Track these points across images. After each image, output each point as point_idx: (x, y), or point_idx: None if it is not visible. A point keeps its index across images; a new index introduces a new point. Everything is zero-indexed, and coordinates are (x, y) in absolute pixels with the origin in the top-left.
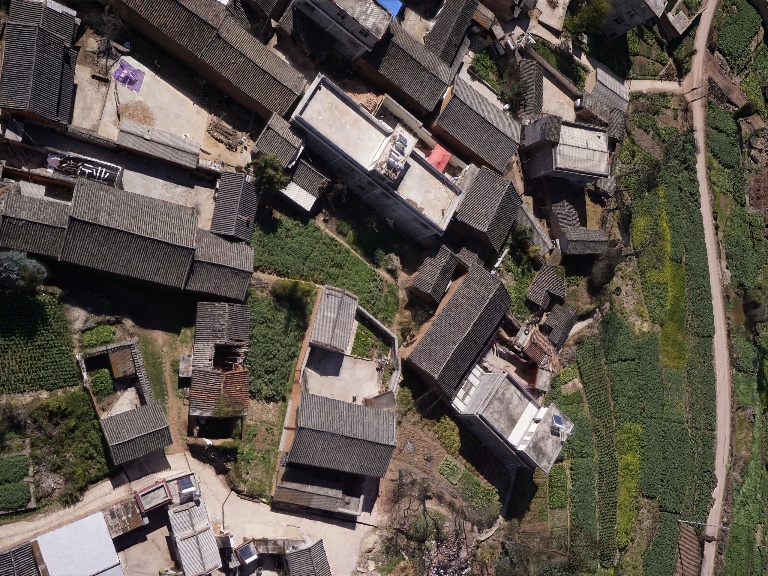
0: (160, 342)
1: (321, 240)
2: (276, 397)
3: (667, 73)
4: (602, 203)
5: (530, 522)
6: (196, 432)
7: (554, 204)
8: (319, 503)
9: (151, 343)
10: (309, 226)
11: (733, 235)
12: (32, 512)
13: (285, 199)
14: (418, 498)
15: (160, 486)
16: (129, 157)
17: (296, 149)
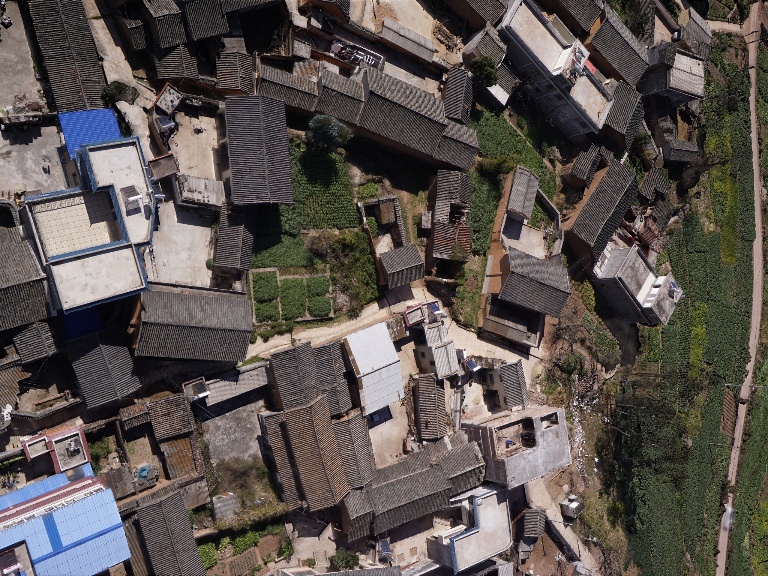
0: (405, 200)
1: (507, 131)
2: (480, 252)
3: (733, 16)
4: (688, 122)
5: (635, 370)
6: (435, 271)
7: (660, 118)
8: (512, 335)
9: (399, 200)
10: (500, 118)
11: (767, 160)
12: (330, 321)
13: (484, 95)
14: (568, 341)
15: (419, 308)
16: (383, 49)
17: (504, 53)
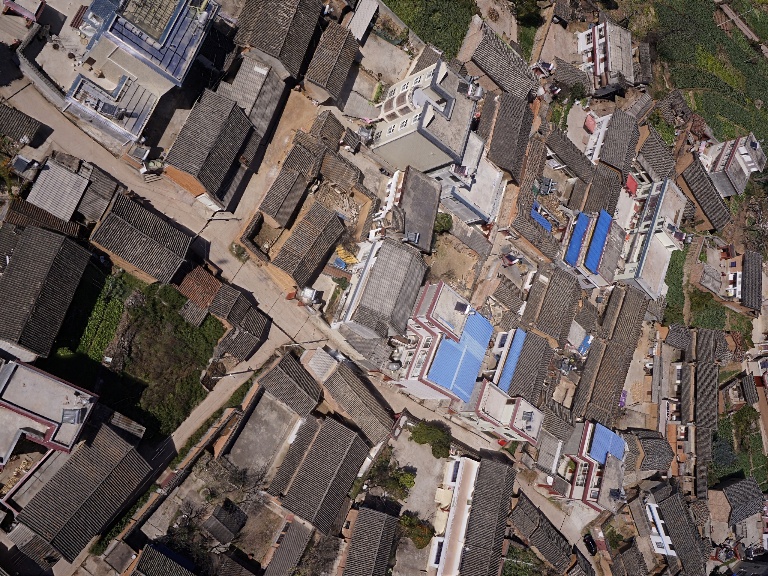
0: None
1: None
2: None
3: None
4: None
5: None
6: None
7: None
8: None
9: None
10: None
11: None
12: None
13: None
14: None
15: (765, 377)
16: None
17: None
